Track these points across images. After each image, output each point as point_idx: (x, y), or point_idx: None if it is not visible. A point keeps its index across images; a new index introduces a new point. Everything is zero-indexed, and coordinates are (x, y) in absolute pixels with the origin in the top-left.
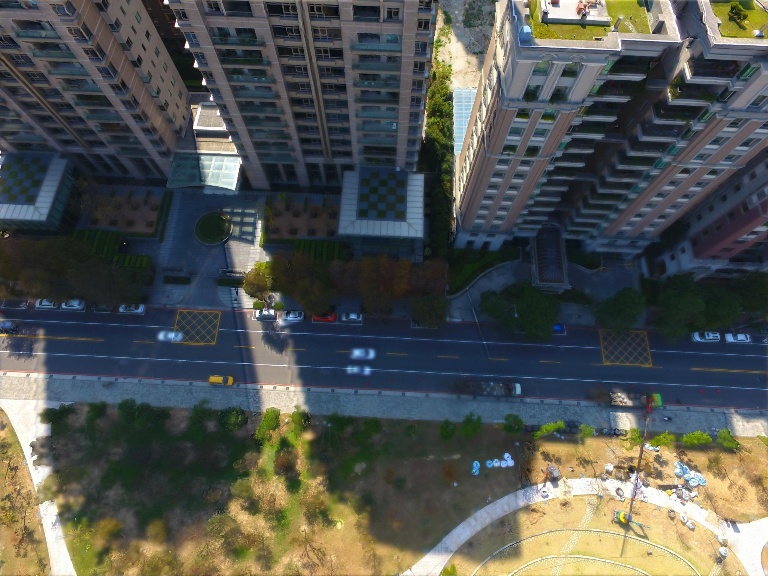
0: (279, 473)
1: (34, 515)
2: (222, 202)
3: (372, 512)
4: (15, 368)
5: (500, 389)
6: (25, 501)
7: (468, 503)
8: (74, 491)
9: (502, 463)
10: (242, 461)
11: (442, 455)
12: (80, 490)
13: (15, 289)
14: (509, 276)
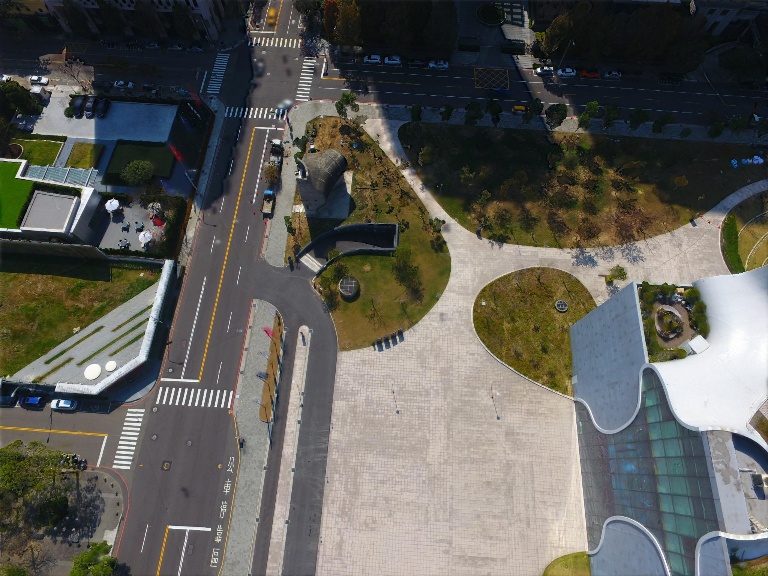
0: (583, 164)
1: (405, 184)
2: None
3: (662, 186)
4: (358, 100)
5: None
6: (395, 176)
7: (734, 183)
8: (430, 171)
9: (754, 160)
10: None
11: (704, 159)
12: (434, 171)
13: (343, 51)
14: None
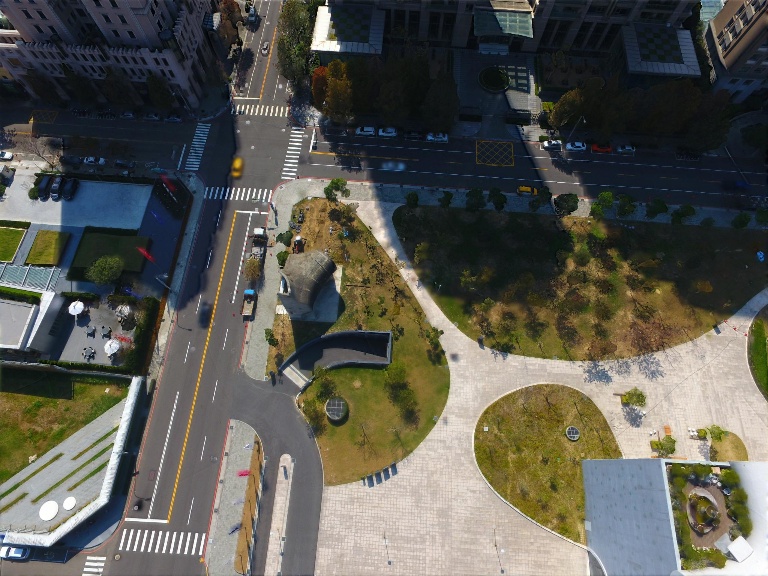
0: (595, 257)
1: (399, 279)
2: (497, 60)
3: (682, 283)
4: (350, 178)
5: (765, 204)
6: None
7: (760, 280)
8: (427, 264)
9: None
10: (561, 248)
11: (726, 249)
12: (432, 264)
13: (334, 121)
14: (751, 124)
